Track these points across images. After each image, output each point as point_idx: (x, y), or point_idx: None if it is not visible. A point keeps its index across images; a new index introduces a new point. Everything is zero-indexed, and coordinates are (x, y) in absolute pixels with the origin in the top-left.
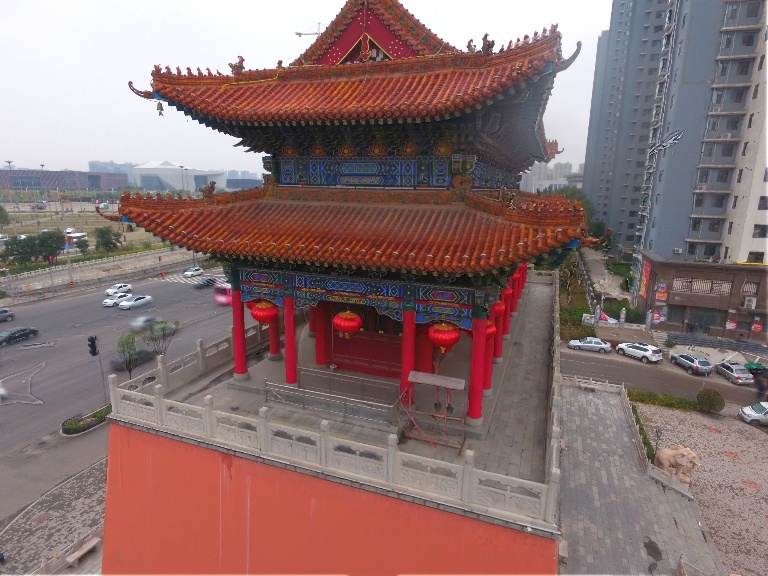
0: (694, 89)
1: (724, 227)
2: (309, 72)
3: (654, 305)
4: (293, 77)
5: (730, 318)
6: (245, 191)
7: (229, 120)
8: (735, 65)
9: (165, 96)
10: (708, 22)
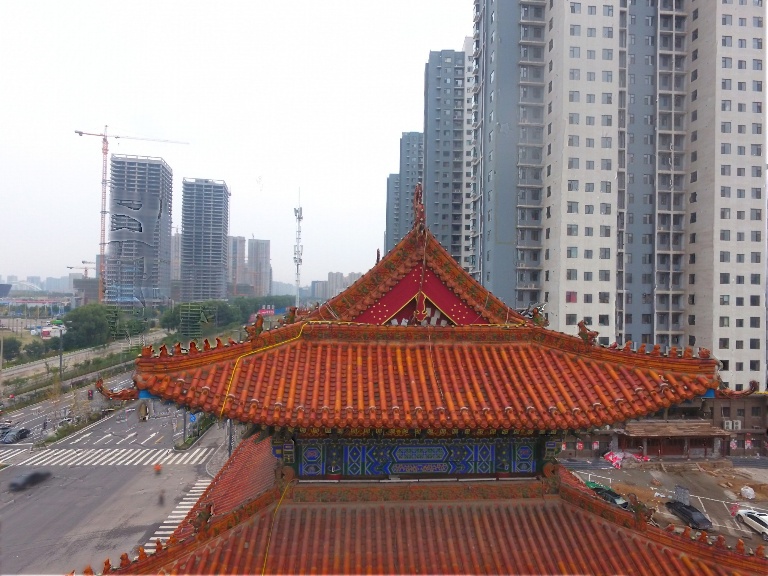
0: (504, 248)
1: None
2: (348, 331)
3: None
4: (324, 335)
5: None
6: (253, 501)
7: (270, 425)
8: (529, 233)
9: (159, 395)
10: (508, 199)
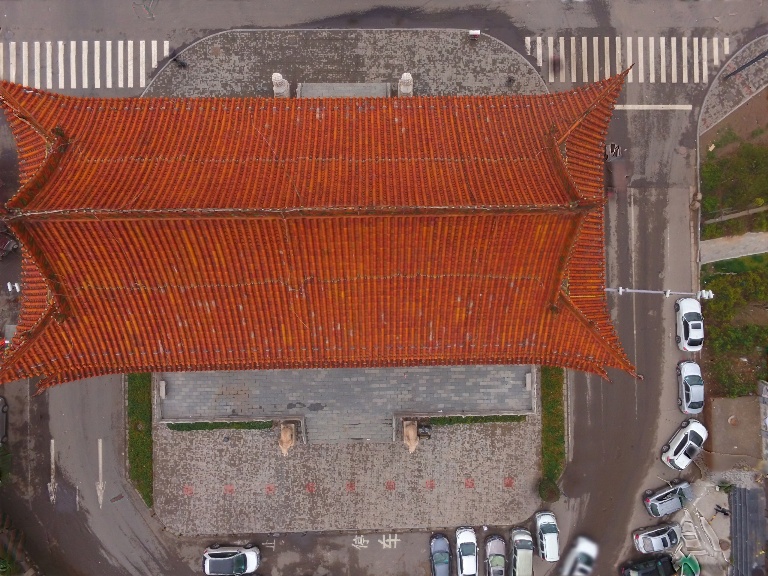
0: None
1: None
2: None
3: None
4: None
5: None
6: None
7: None
8: None
9: None
10: None
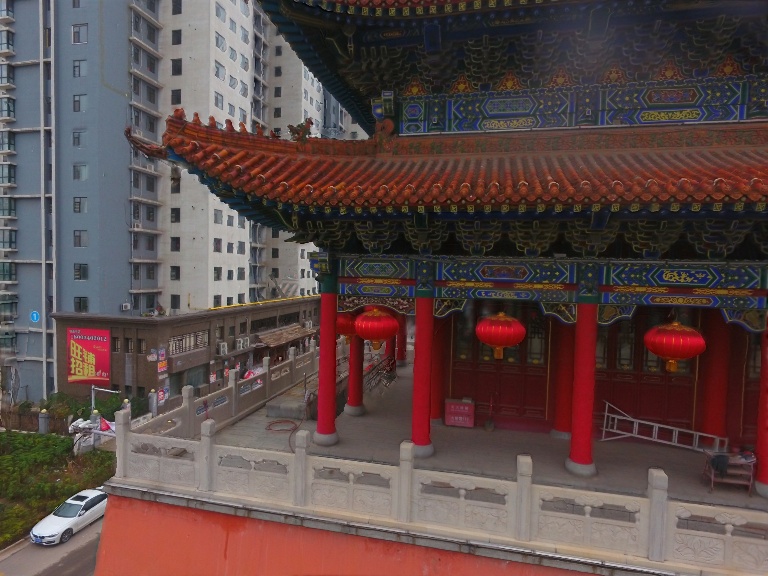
0: (113, 97)
1: (159, 273)
2: None
3: (157, 381)
4: None
5: (212, 370)
6: None
7: None
8: (145, 87)
9: None
10: (117, 19)
